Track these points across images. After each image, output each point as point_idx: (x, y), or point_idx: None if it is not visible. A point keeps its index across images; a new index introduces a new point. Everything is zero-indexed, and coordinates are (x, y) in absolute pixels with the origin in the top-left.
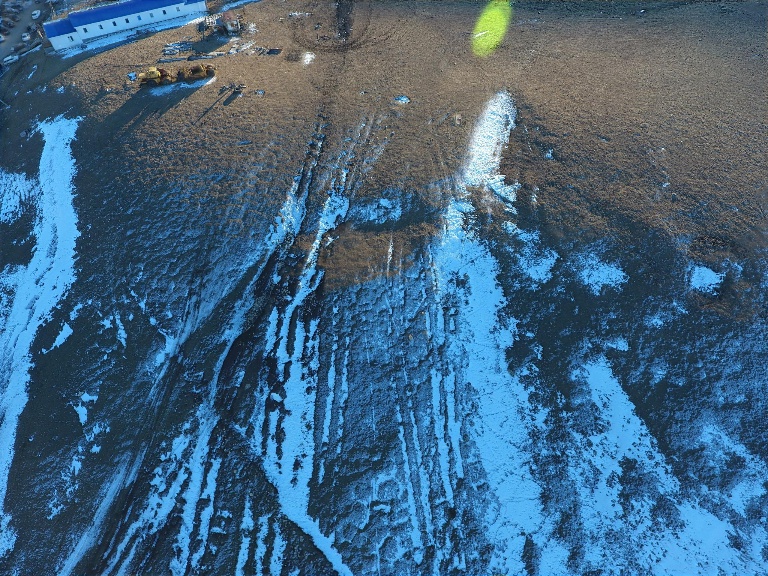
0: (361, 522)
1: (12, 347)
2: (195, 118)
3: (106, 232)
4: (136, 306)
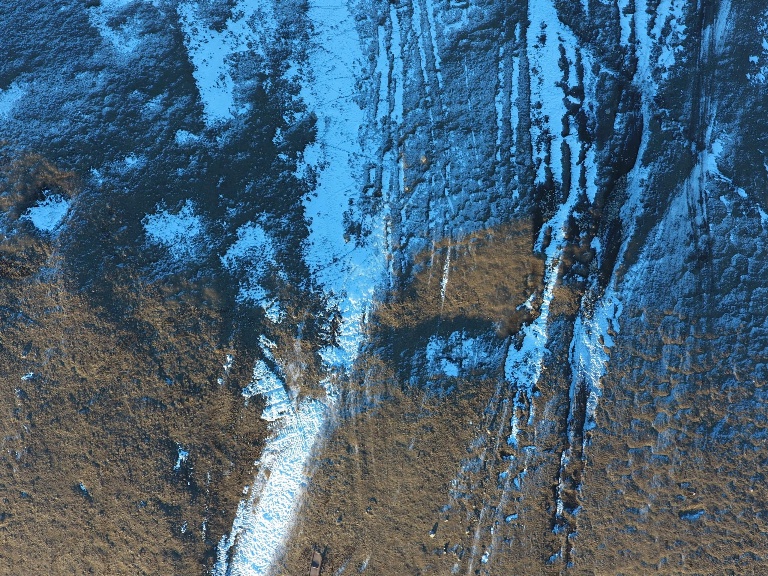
0: None
1: None
2: None
3: None
4: None
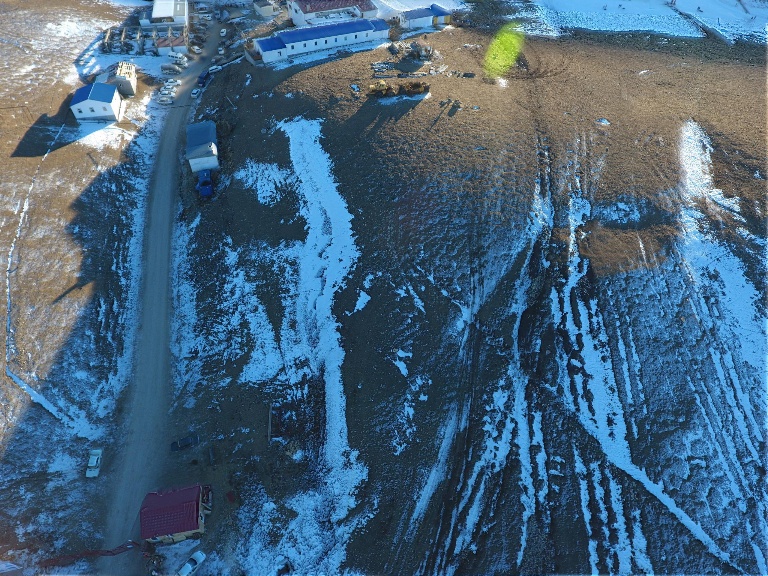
0: (684, 473)
1: (313, 309)
2: (428, 125)
3: (379, 216)
4: (425, 279)
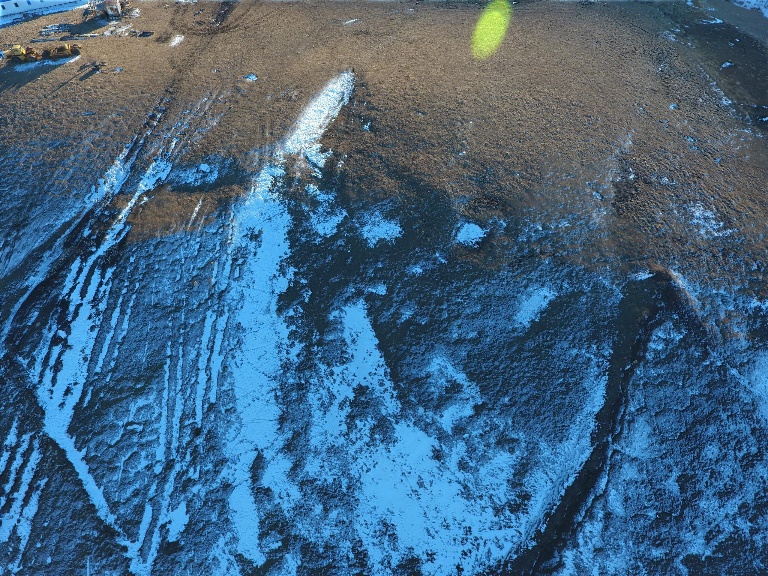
0: (113, 439)
1: None
2: (48, 91)
3: None
4: None
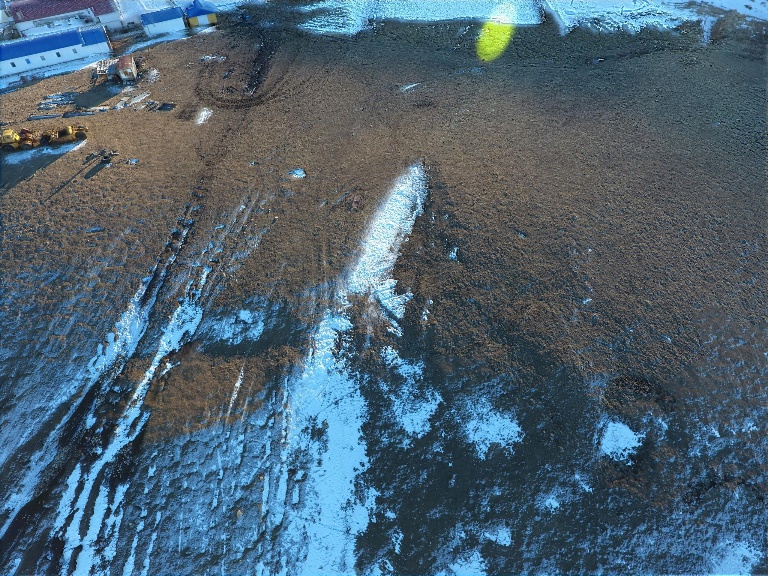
0: None
1: None
2: (46, 195)
3: None
4: None
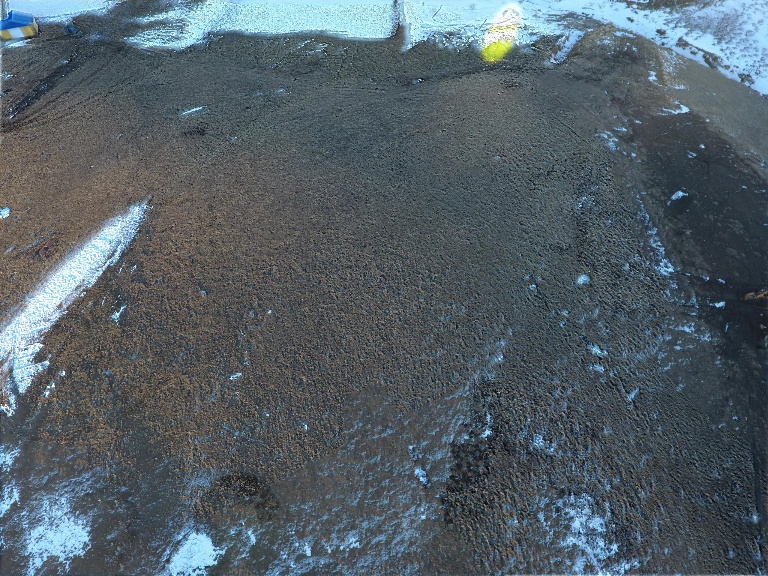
0: None
1: None
2: None
3: None
4: None
